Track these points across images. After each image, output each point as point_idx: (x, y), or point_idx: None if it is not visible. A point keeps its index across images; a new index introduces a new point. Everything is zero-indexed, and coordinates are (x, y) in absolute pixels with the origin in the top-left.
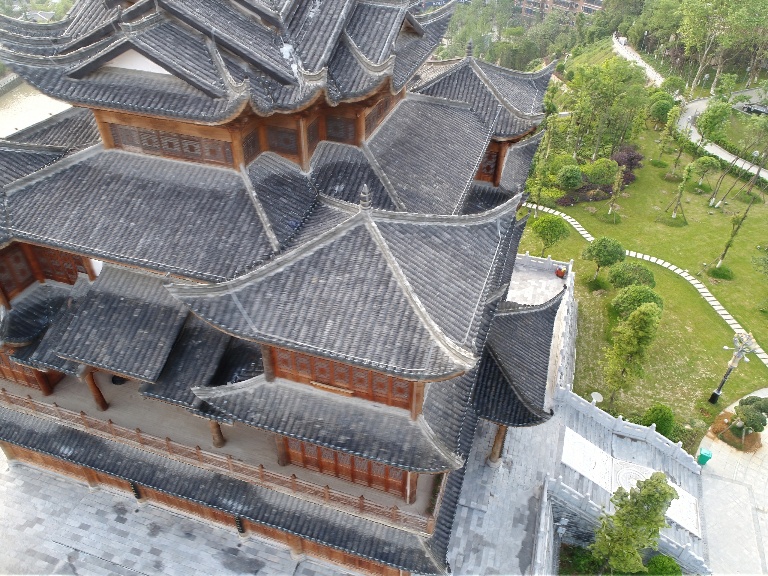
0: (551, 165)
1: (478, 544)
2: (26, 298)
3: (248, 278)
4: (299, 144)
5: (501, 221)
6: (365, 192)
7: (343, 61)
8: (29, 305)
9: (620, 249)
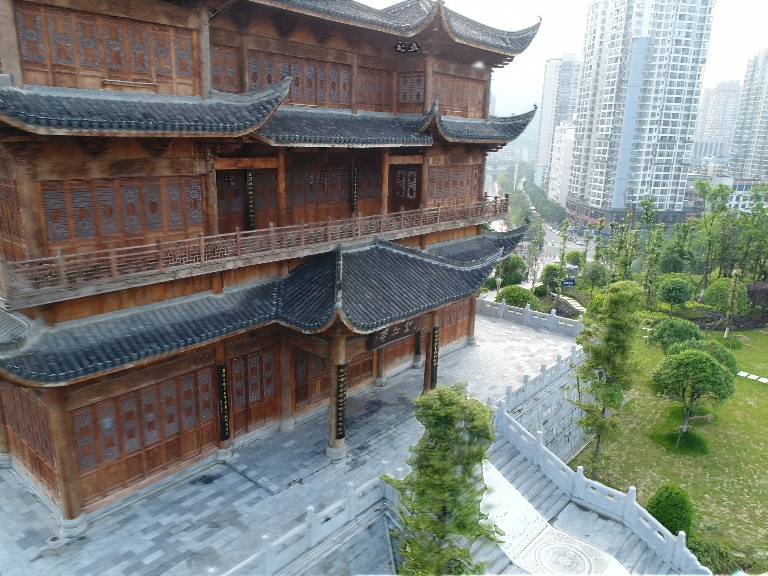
0: None
1: (225, 520)
2: None
3: None
4: None
5: None
6: None
7: None
8: None
9: (694, 331)
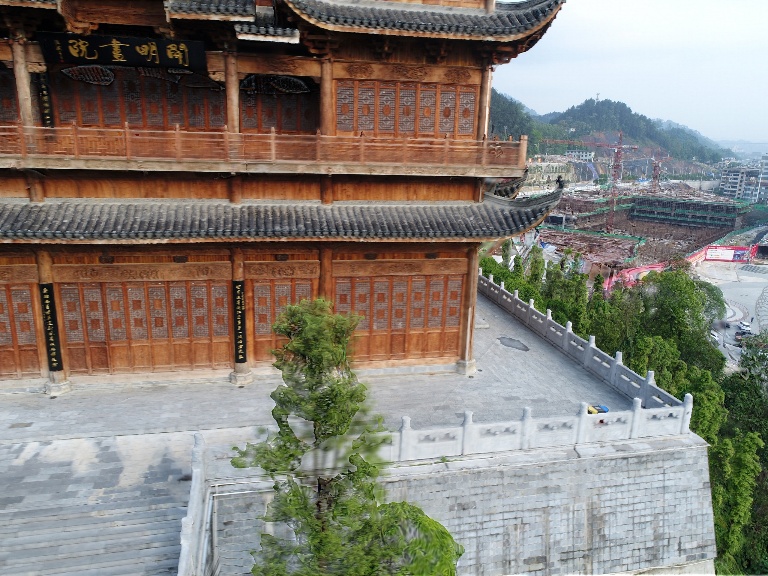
0: None
1: None
2: None
3: None
4: None
5: None
6: None
7: None
8: None
9: None
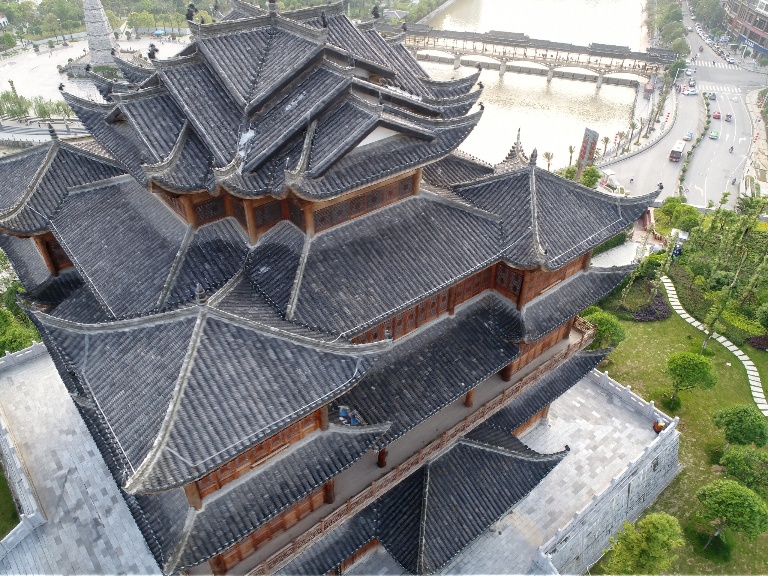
0: (761, 294)
1: None
2: (74, 271)
3: (100, 327)
4: (246, 220)
5: (363, 360)
6: (196, 290)
7: (294, 157)
8: (72, 278)
9: (760, 431)
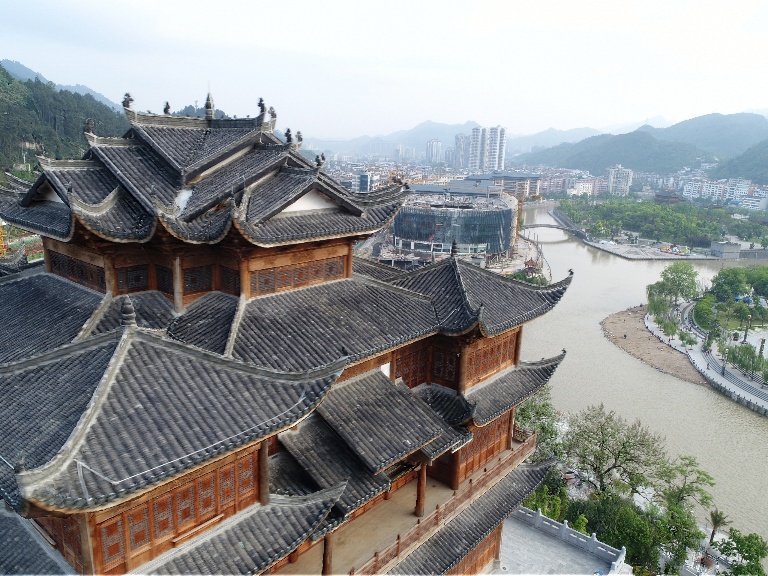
0: None
1: None
2: None
3: None
4: None
5: None
6: None
7: None
8: None
9: None
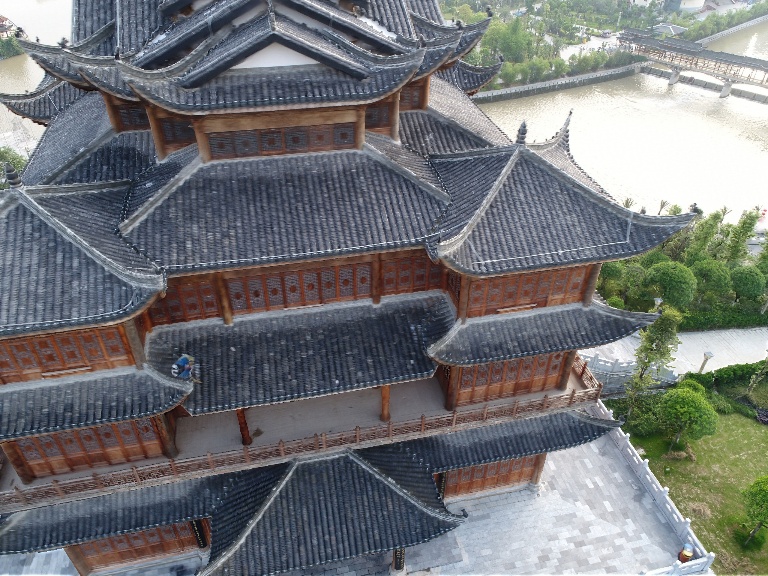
0: None
1: None
2: None
3: None
4: None
5: (138, 292)
6: None
7: None
8: None
9: None
